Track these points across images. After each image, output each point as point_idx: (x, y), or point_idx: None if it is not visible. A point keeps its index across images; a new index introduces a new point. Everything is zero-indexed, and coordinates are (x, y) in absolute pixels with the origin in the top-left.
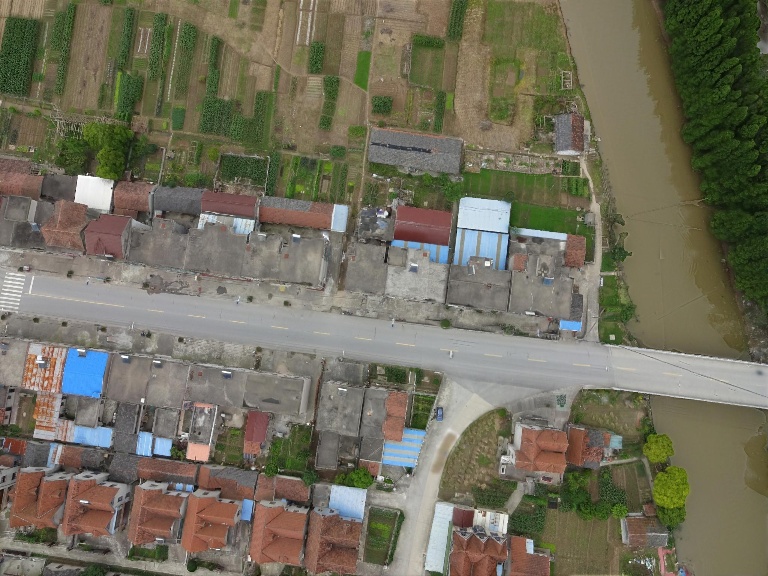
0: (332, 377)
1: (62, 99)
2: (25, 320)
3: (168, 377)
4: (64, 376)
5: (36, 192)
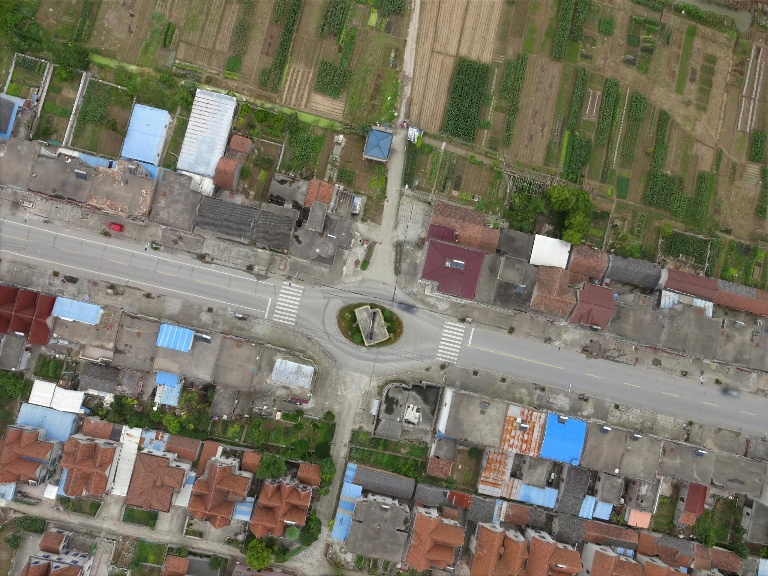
0: (754, 455)
1: (508, 150)
2: (463, 372)
3: (642, 450)
4: (544, 441)
5: (495, 246)
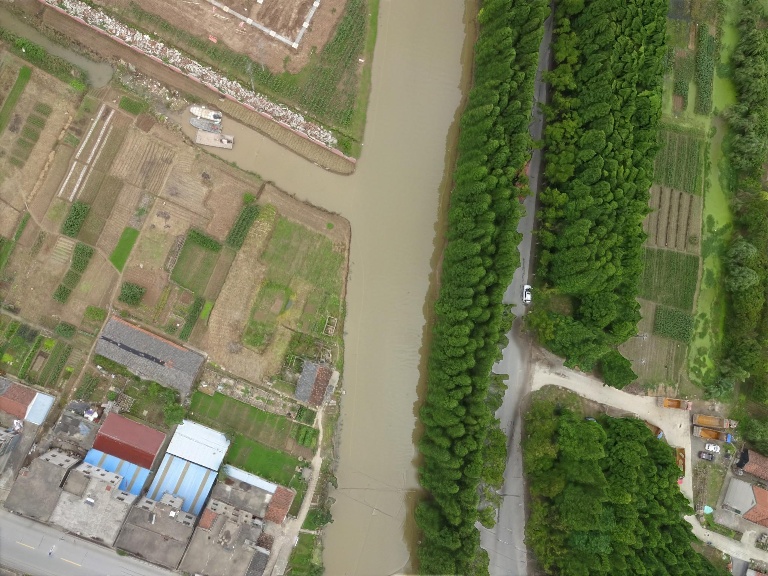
0: None
1: None
2: None
3: None
4: None
5: None
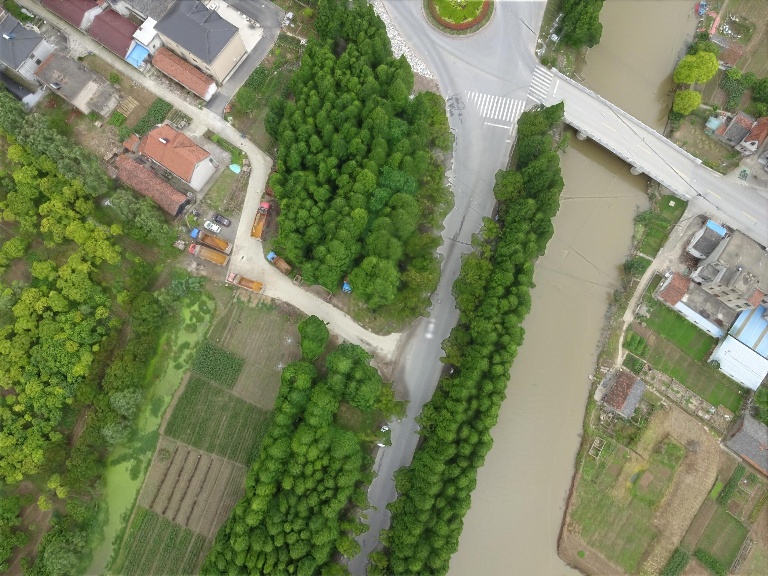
0: None
1: None
2: None
3: None
4: None
5: None
